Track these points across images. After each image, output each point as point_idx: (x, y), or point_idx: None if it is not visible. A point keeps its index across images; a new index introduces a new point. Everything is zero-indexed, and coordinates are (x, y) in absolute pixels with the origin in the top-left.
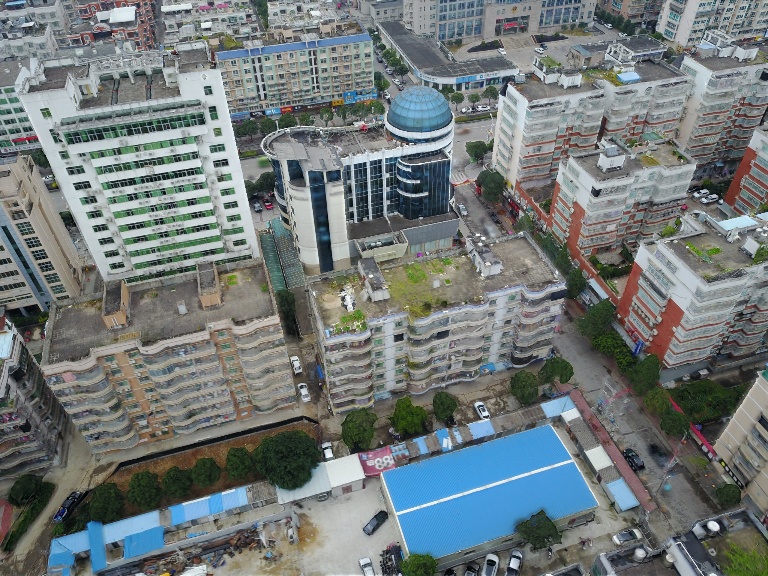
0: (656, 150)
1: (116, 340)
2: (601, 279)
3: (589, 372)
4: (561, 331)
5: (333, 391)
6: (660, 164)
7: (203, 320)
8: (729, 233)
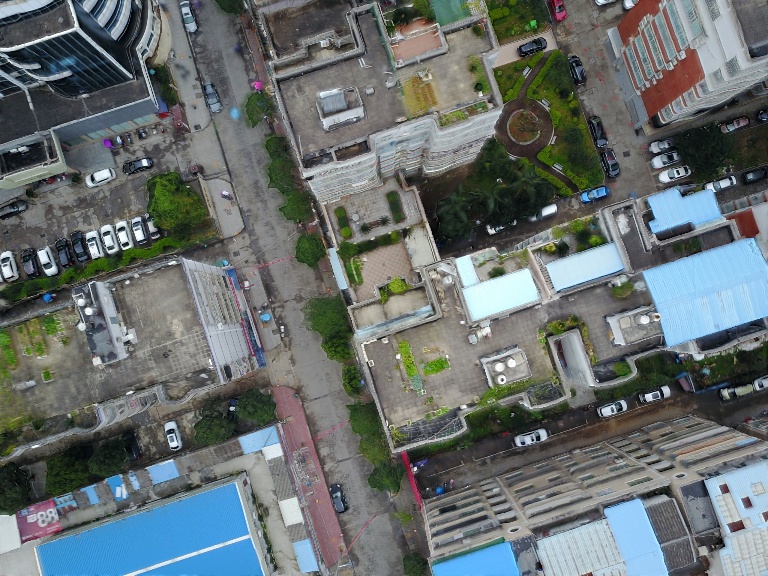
0: (446, 53)
1: None
2: (340, 261)
3: (319, 369)
4: (299, 297)
5: None
6: (437, 103)
7: None
8: (475, 325)
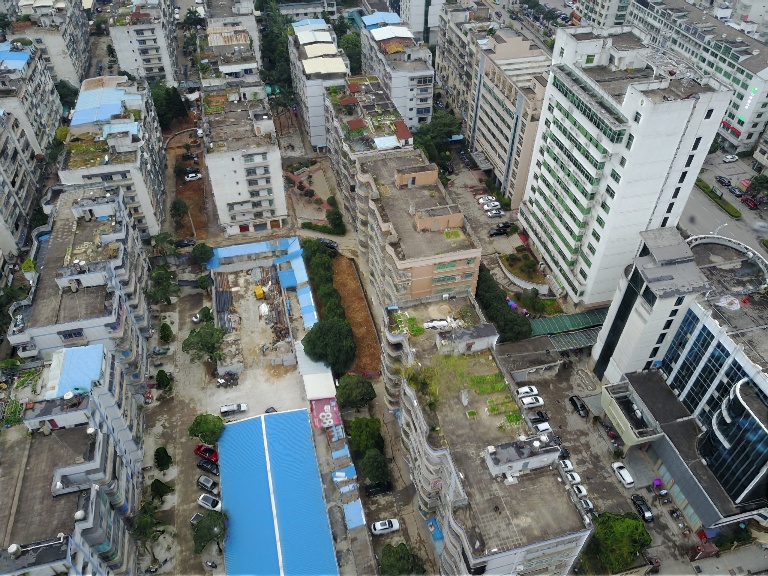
0: None
1: (382, 185)
2: None
3: None
4: None
5: (381, 357)
6: None
7: (402, 224)
8: None
